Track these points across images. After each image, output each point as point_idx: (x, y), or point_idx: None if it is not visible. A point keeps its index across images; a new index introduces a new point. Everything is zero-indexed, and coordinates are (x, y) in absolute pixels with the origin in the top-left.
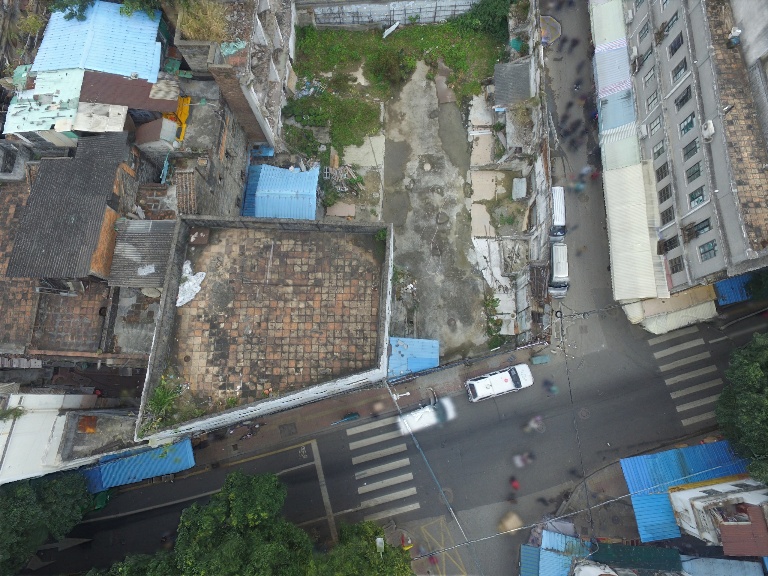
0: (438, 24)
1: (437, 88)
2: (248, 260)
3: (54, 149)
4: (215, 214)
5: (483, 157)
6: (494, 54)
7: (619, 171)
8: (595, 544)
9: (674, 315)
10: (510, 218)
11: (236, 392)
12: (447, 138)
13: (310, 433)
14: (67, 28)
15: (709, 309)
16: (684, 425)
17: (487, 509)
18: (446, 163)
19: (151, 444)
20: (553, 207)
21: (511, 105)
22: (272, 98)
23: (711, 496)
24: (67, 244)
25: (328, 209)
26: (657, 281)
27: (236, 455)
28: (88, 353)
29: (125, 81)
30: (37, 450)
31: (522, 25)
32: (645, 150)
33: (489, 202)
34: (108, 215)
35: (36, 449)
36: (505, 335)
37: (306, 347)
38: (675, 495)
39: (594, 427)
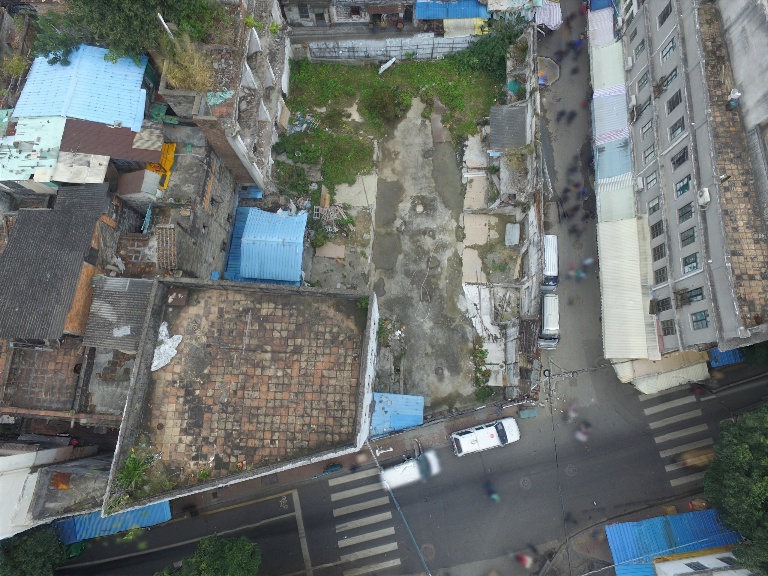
0: (435, 61)
1: (432, 127)
2: (226, 323)
3: (34, 195)
4: (198, 265)
5: (477, 200)
6: (491, 94)
7: (613, 224)
8: None
9: (665, 375)
10: (502, 265)
11: (209, 464)
12: (441, 179)
13: (291, 482)
14: (51, 72)
15: (701, 370)
16: (673, 485)
17: (469, 567)
18: (439, 205)
19: None
20: (544, 261)
21: (506, 150)
22: (262, 138)
23: (696, 573)
24: (41, 303)
25: (317, 250)
26: (648, 342)
27: (215, 503)
28: (61, 413)
29: (108, 130)
30: (6, 512)
31: (520, 68)
32: (641, 203)
33: (481, 247)
34: (85, 271)
35: (5, 511)
36: (493, 386)
37: (282, 418)
38: (660, 567)
39: (581, 485)
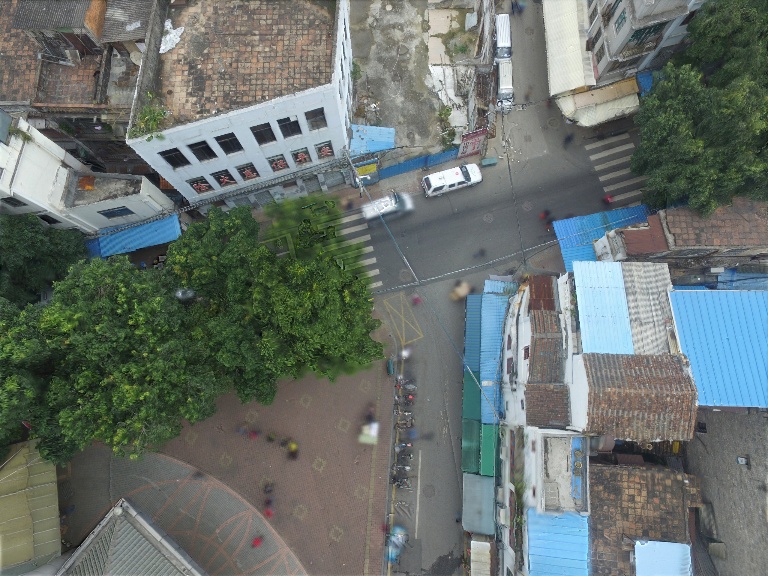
0: None
1: None
2: (221, 17)
3: None
4: None
5: None
6: None
7: None
8: (527, 276)
9: (602, 108)
10: (463, 46)
11: None
12: None
13: (285, 228)
14: None
15: (633, 102)
16: None
17: (441, 284)
18: (406, 4)
19: (142, 194)
20: (495, 15)
21: None
22: None
23: None
24: (64, 4)
25: None
26: (585, 72)
27: None
28: (85, 104)
29: None
30: (44, 186)
31: None
32: None
33: (444, 35)
34: None
35: (43, 184)
36: (458, 144)
37: (271, 80)
38: (597, 241)
39: (536, 216)
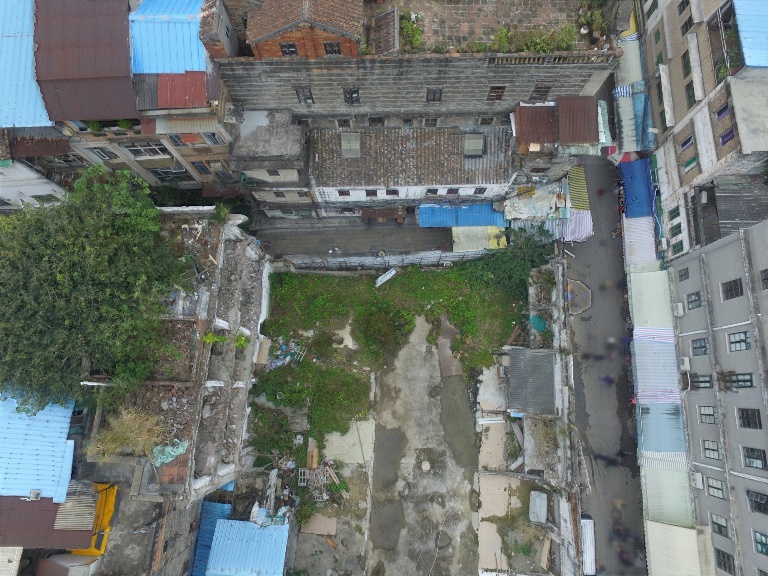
0: (442, 271)
1: (440, 355)
2: None
3: None
4: None
5: (494, 455)
6: (509, 316)
7: (666, 529)
8: None
9: None
10: (526, 549)
11: None
12: (451, 426)
13: None
14: None
15: None
16: None
17: None
18: (449, 461)
19: None
20: None
21: (530, 411)
22: (234, 410)
23: None
24: None
25: (303, 525)
26: None
27: None
28: None
29: (22, 505)
30: None
31: (545, 306)
32: (699, 502)
33: (501, 520)
34: None
35: None
36: None
37: None
38: None
39: None
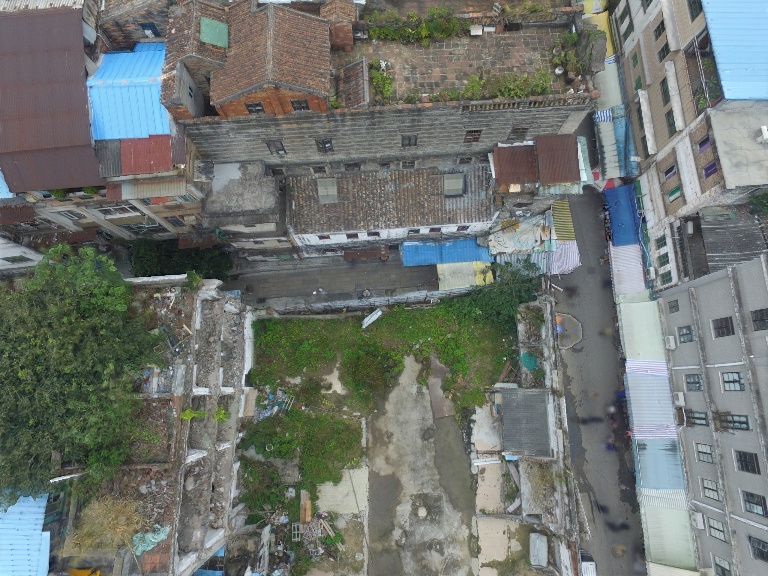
0: (429, 308)
1: (431, 396)
2: None
3: None
4: None
5: (491, 497)
6: (500, 352)
7: (669, 571)
8: None
9: None
10: None
11: None
12: (445, 469)
13: None
14: None
15: None
16: None
17: None
18: (445, 506)
19: None
20: None
21: (525, 453)
22: (221, 472)
23: None
24: None
25: None
26: None
27: None
28: None
29: None
30: None
31: (535, 344)
32: (701, 542)
33: (501, 565)
34: None
35: None
36: None
37: None
38: None
39: None
